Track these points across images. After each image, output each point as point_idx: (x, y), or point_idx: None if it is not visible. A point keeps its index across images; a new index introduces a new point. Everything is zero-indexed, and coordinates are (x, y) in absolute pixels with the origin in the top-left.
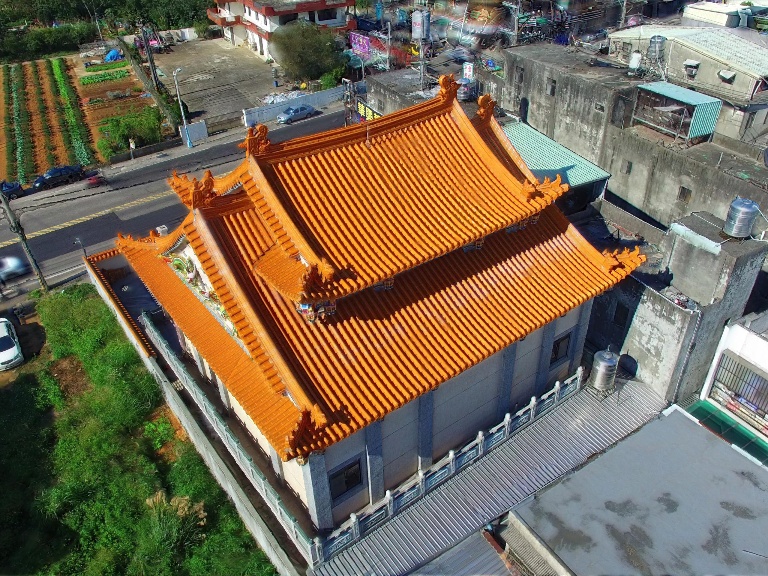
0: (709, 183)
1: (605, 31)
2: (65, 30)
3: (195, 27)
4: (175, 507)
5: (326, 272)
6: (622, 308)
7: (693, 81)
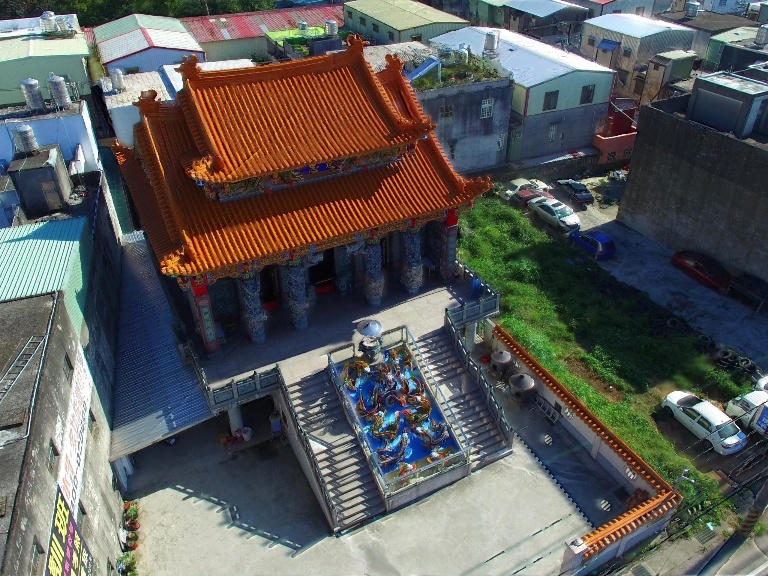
0: None
1: None
2: None
3: None
4: None
5: None
6: None
7: None
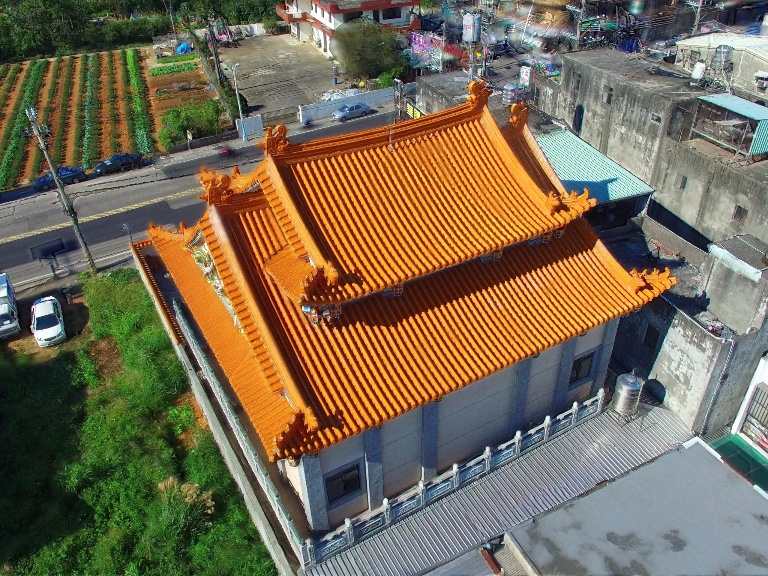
0: (767, 204)
1: (676, 38)
2: (141, 22)
3: (263, 22)
4: (185, 493)
5: (331, 276)
6: (653, 331)
7: (763, 94)
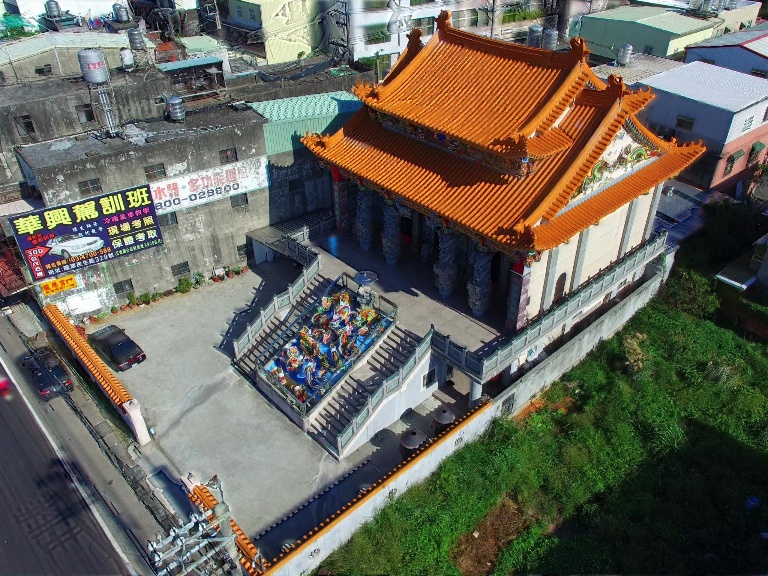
0: None
1: None
2: None
3: None
4: None
5: None
6: None
7: None
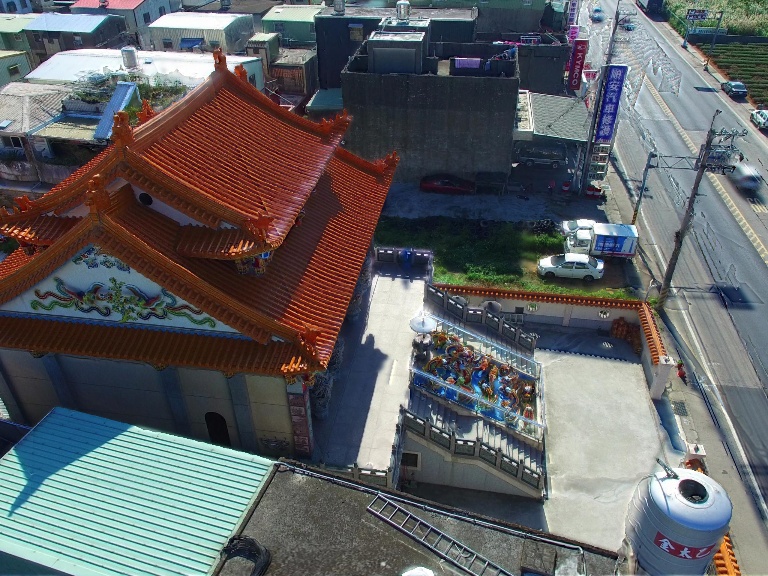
0: None
1: None
2: None
3: None
4: None
5: None
6: None
7: None
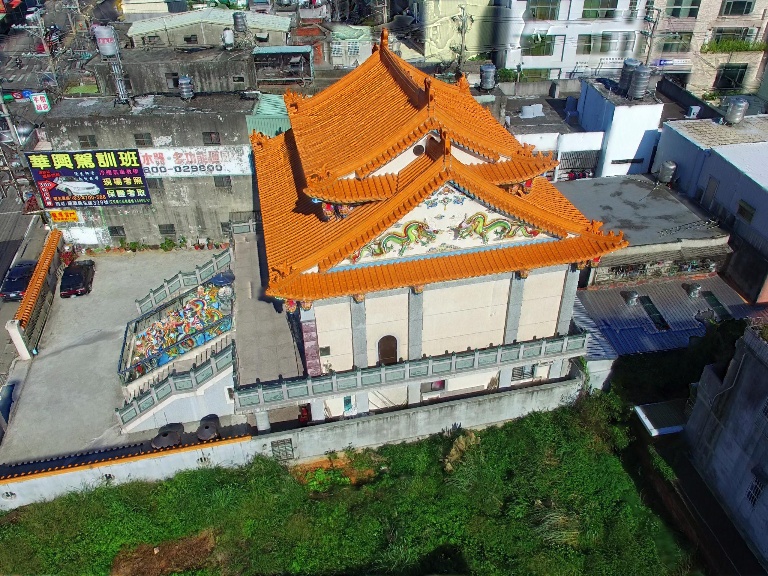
0: None
1: None
2: None
3: None
4: None
5: None
6: None
7: None
